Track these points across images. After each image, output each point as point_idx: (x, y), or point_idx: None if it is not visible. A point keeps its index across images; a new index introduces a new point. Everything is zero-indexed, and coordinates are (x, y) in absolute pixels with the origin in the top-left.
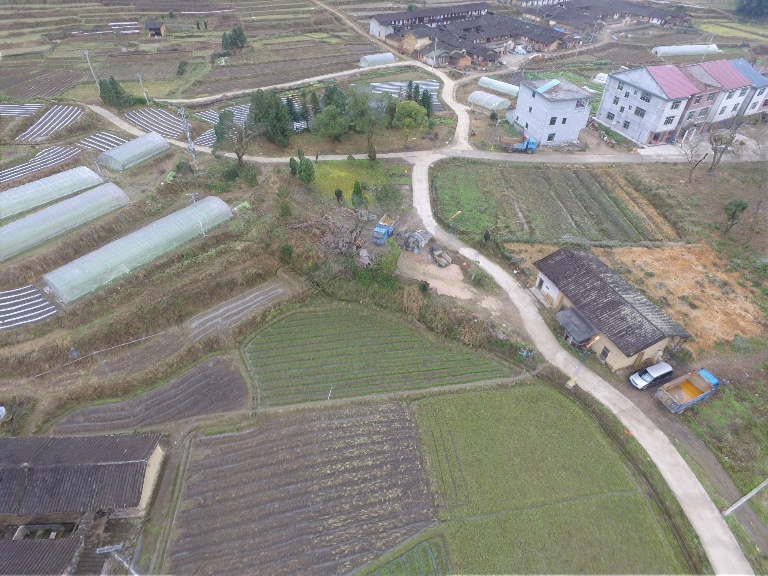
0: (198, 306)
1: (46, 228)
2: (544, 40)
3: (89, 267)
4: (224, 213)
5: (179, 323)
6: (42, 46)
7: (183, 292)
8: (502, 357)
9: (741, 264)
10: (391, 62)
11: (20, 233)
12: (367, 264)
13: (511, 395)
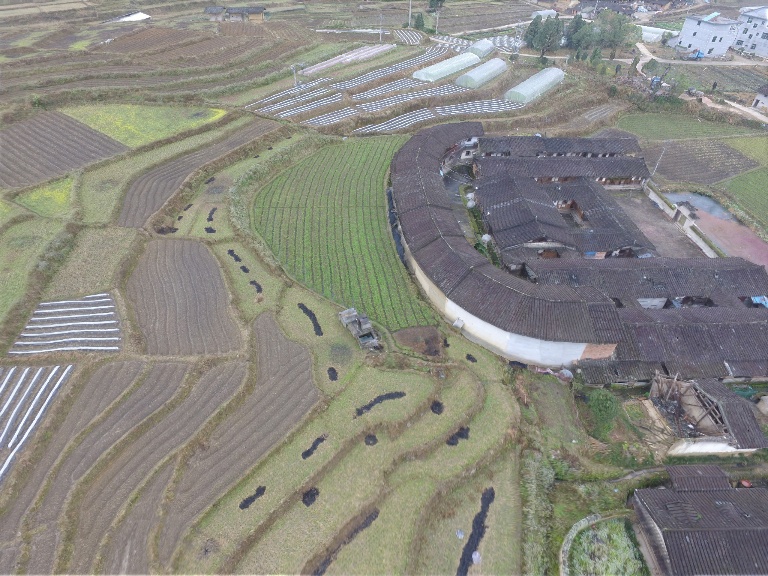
0: (582, 110)
1: (488, 74)
2: (660, 2)
3: None
4: (562, 75)
5: None
6: (296, 6)
7: (576, 102)
8: (752, 128)
9: None
10: None
11: (481, 75)
12: (660, 94)
13: (765, 138)
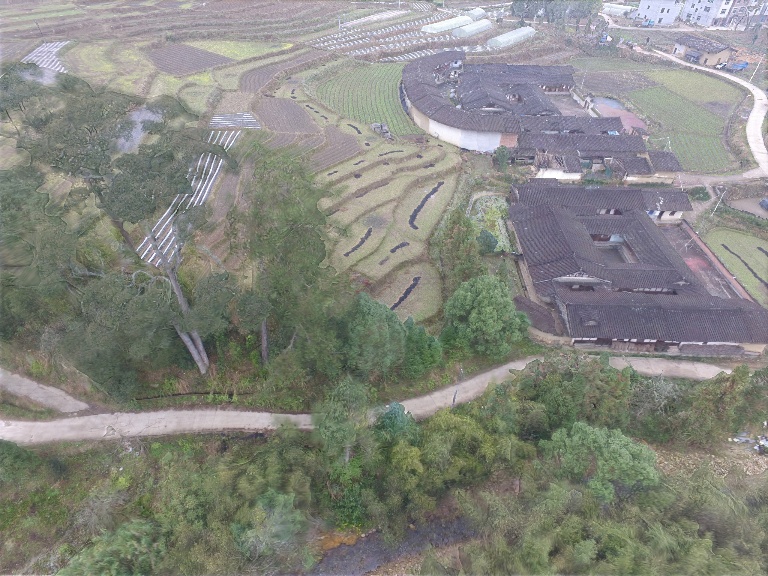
0: (544, 54)
1: (476, 29)
2: None
3: None
4: (533, 31)
5: (541, 57)
6: None
7: None
8: None
9: (758, 49)
10: None
11: (471, 28)
12: (604, 44)
13: None
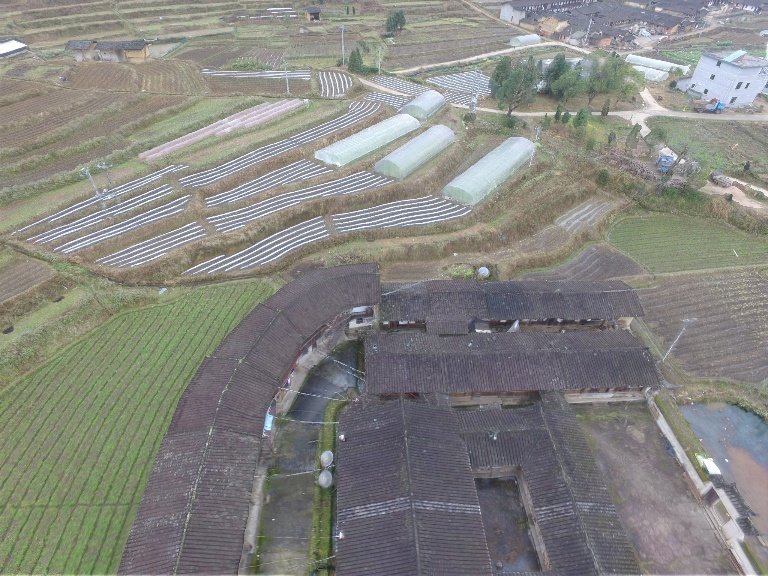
0: (558, 212)
1: (423, 155)
2: (665, 24)
3: (478, 181)
4: None
5: (552, 222)
6: (224, 28)
7: (549, 200)
8: None
9: None
10: (538, 42)
11: (412, 157)
12: (671, 184)
13: None
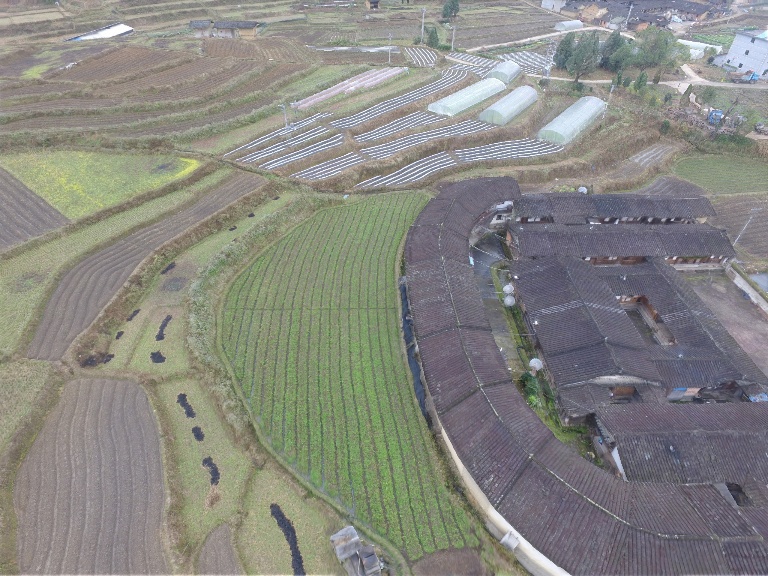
0: (631, 152)
1: (517, 107)
2: (695, 11)
3: (566, 126)
4: (603, 106)
5: None
6: (295, 15)
7: (624, 142)
8: None
9: None
10: (581, 27)
11: (510, 108)
12: (722, 132)
13: None
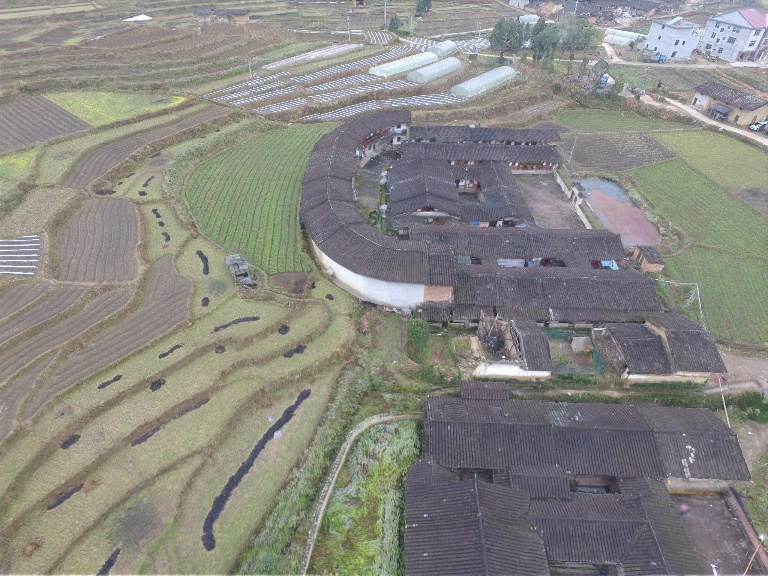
0: (524, 105)
1: (439, 71)
2: (645, 8)
3: (473, 84)
4: (513, 73)
5: (519, 110)
6: (290, 10)
7: (518, 97)
8: (683, 124)
9: None
10: None
11: (431, 71)
12: (602, 92)
13: (693, 133)
